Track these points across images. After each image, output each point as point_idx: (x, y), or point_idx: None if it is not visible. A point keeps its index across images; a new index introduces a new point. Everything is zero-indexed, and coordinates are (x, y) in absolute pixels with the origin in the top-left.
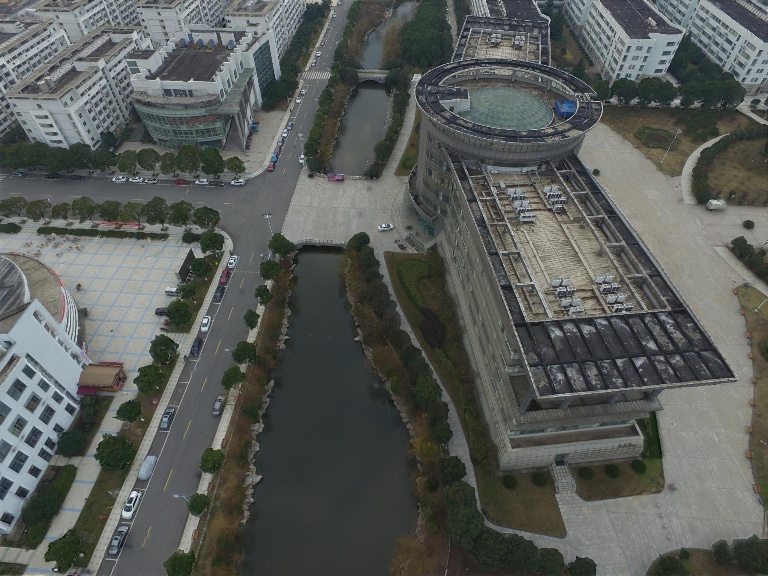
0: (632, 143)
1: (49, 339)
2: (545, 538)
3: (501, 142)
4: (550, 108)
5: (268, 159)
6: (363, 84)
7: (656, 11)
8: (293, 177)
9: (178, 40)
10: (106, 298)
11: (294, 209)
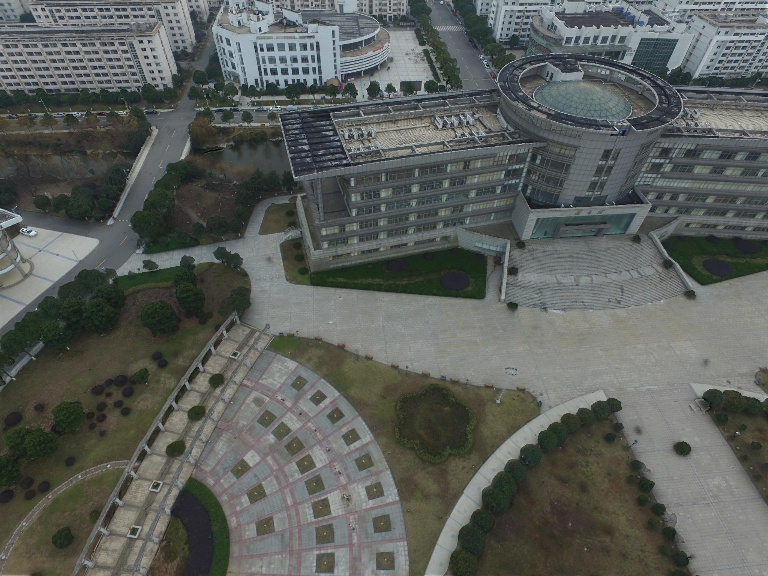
0: None
1: (331, 48)
2: (259, 227)
3: None
4: None
5: None
6: None
7: None
8: None
9: (618, 7)
10: (385, 78)
11: None
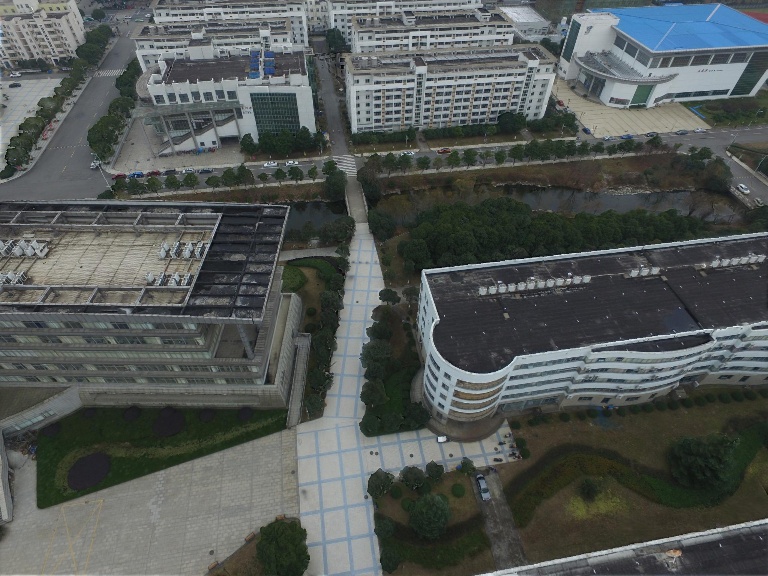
0: None
1: None
2: None
3: None
4: None
5: None
6: None
7: None
8: None
9: None
10: None
11: None
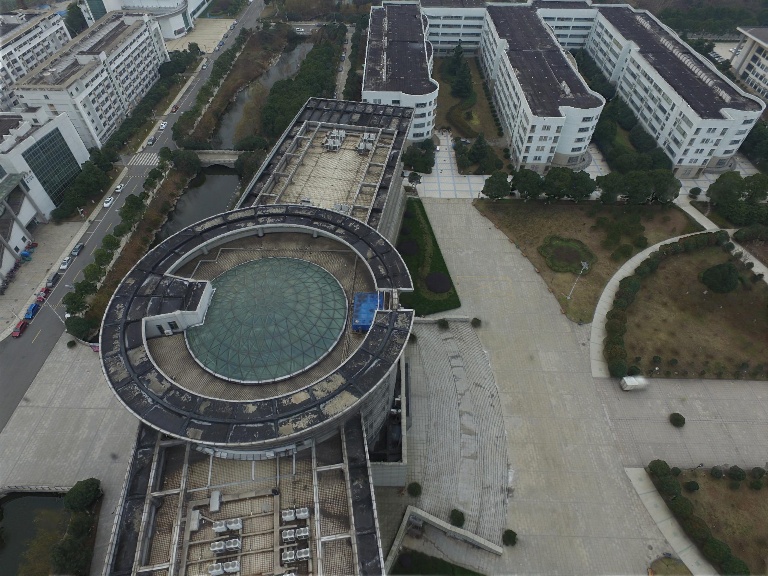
0: (533, 264)
1: None
2: None
3: (194, 442)
4: (343, 309)
5: (20, 314)
6: (210, 169)
7: (574, 70)
8: (45, 347)
9: None
10: None
11: (20, 415)
